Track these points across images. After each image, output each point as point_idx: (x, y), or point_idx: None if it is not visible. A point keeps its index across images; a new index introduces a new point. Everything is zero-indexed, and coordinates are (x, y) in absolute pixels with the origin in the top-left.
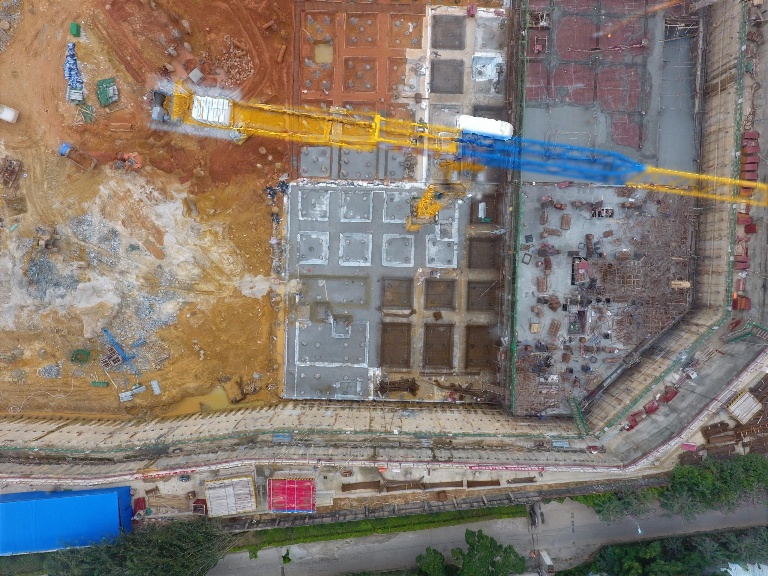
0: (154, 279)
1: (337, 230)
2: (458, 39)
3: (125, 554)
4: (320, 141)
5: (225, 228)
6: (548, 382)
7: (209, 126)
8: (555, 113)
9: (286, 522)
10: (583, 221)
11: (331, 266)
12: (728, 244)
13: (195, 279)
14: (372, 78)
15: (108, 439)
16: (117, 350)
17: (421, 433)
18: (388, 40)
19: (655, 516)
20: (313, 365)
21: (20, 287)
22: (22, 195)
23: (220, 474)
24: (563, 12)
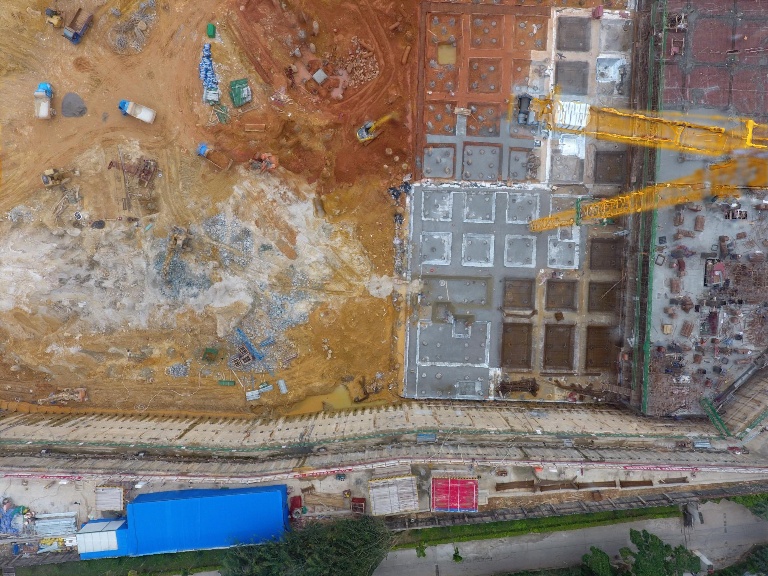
0: (286, 279)
1: (460, 231)
2: (582, 41)
3: (302, 552)
4: (444, 142)
5: (354, 228)
6: (680, 383)
7: (333, 127)
8: (690, 115)
9: (446, 521)
10: (716, 223)
11: (453, 266)
12: None
13: (326, 279)
14: (496, 79)
15: (248, 438)
16: (248, 349)
17: (564, 433)
18: (513, 42)
19: None
20: (434, 365)
21: (154, 286)
22: (156, 195)
23: (376, 473)
24: (700, 14)
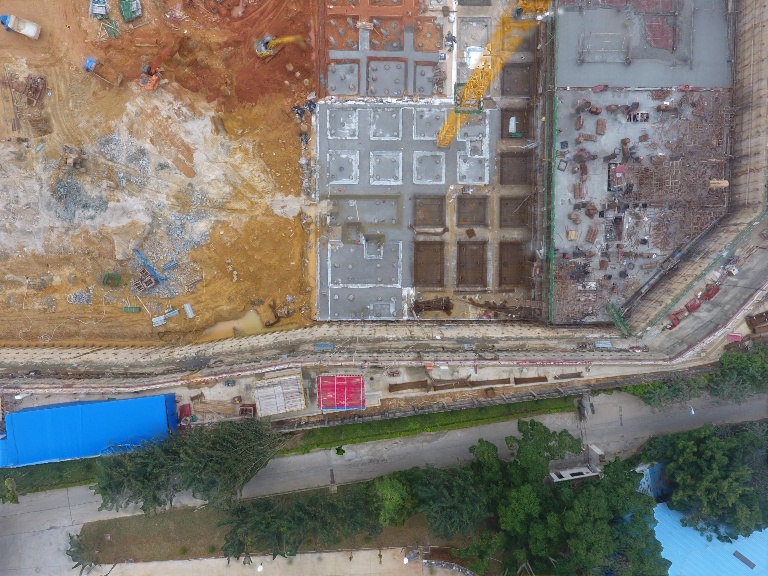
0: (185, 198)
1: (367, 148)
2: None
3: (178, 449)
4: (347, 58)
5: (255, 145)
6: (586, 290)
7: (233, 45)
8: (588, 16)
9: (335, 421)
10: (618, 126)
11: (362, 185)
12: (767, 139)
13: (226, 197)
14: None
15: (146, 356)
16: (149, 272)
17: (464, 338)
18: None
19: (702, 407)
20: (346, 287)
21: (48, 209)
22: (47, 115)
23: (266, 377)
24: None
